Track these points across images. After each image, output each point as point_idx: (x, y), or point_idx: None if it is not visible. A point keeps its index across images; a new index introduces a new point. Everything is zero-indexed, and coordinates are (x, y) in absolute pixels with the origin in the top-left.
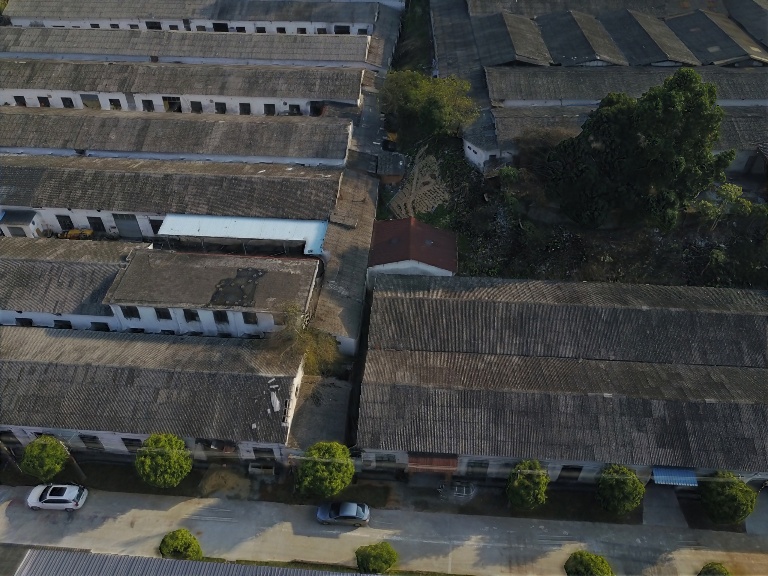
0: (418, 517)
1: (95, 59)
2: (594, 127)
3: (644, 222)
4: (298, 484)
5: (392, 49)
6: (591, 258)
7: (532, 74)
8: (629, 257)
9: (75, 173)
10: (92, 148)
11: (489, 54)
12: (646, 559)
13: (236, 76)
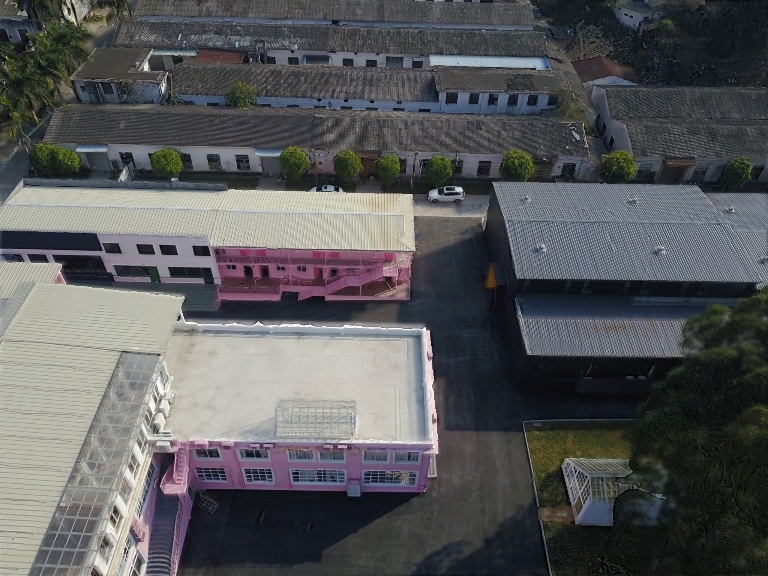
0: None
1: None
2: None
3: (761, 50)
4: (607, 172)
5: None
6: (722, 80)
7: None
8: (746, 80)
9: (353, 30)
10: (346, 19)
11: None
12: None
13: None
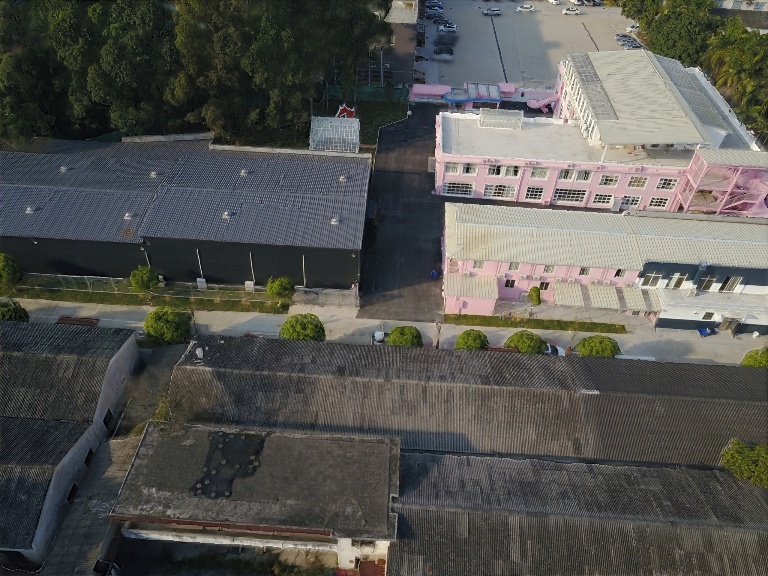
0: None
1: None
2: None
3: None
4: None
5: None
6: None
7: None
8: None
9: None
10: None
11: None
12: None
13: None
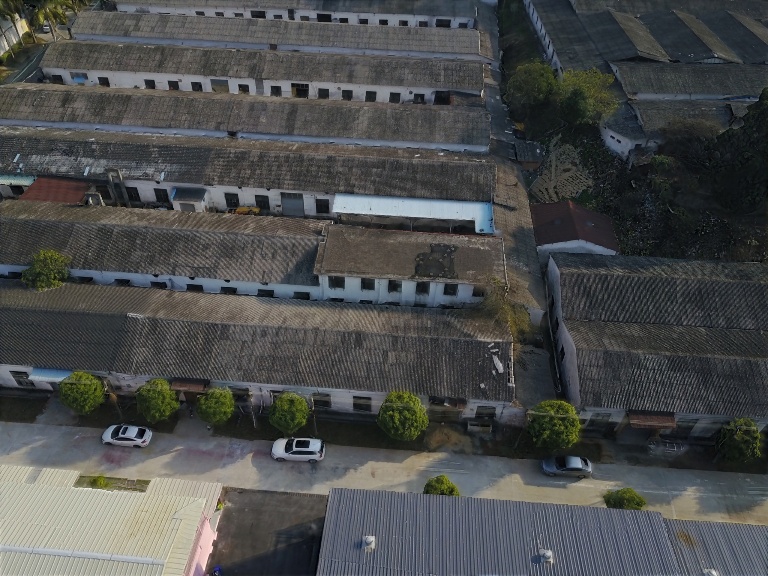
0: (633, 470)
1: (215, 46)
2: (759, 118)
3: None
4: (535, 437)
5: (497, 43)
6: (739, 241)
7: (660, 69)
8: None
9: (241, 153)
10: (245, 130)
11: (609, 50)
12: None
13: (362, 65)
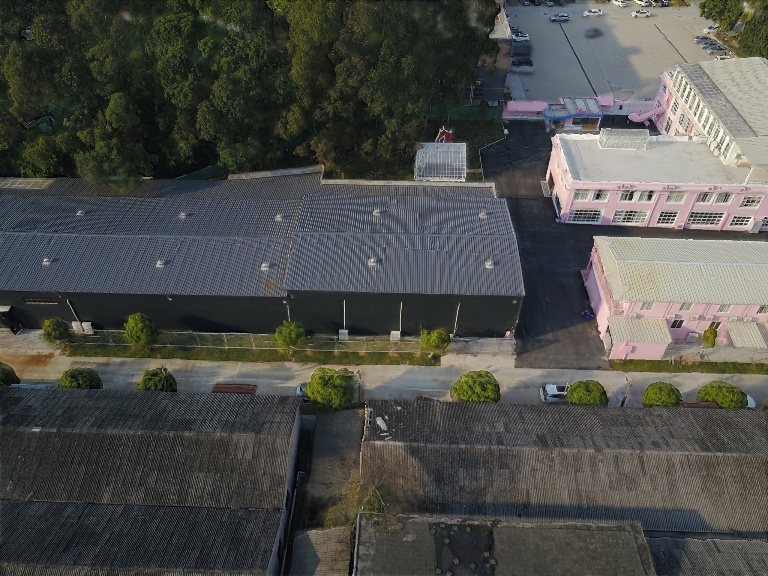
0: None
1: None
2: None
3: None
4: (352, 373)
5: None
6: None
7: None
8: None
9: None
10: None
11: None
12: None
13: None
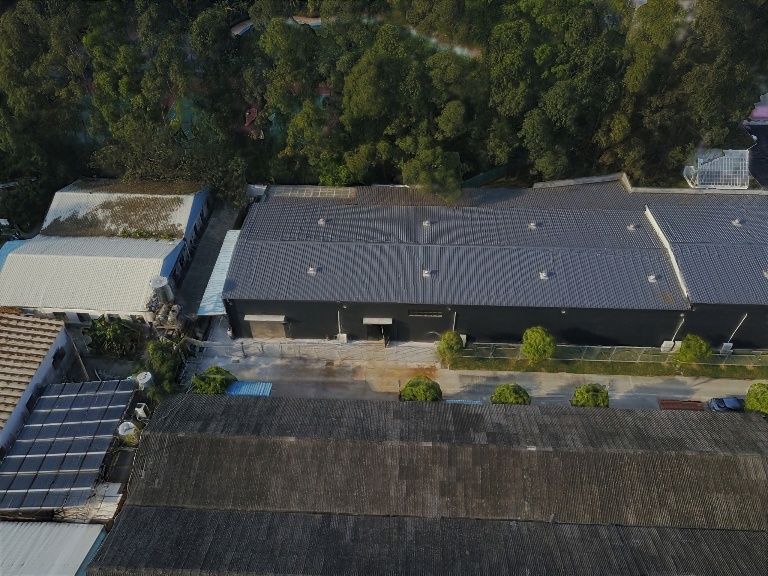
0: None
1: None
2: None
3: None
4: None
5: None
6: None
7: None
8: None
9: None
10: None
11: None
12: (481, 387)
13: None
